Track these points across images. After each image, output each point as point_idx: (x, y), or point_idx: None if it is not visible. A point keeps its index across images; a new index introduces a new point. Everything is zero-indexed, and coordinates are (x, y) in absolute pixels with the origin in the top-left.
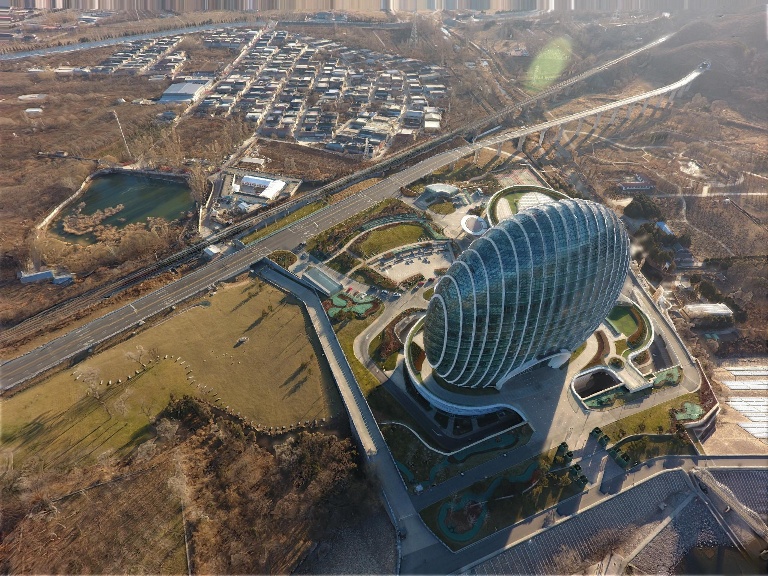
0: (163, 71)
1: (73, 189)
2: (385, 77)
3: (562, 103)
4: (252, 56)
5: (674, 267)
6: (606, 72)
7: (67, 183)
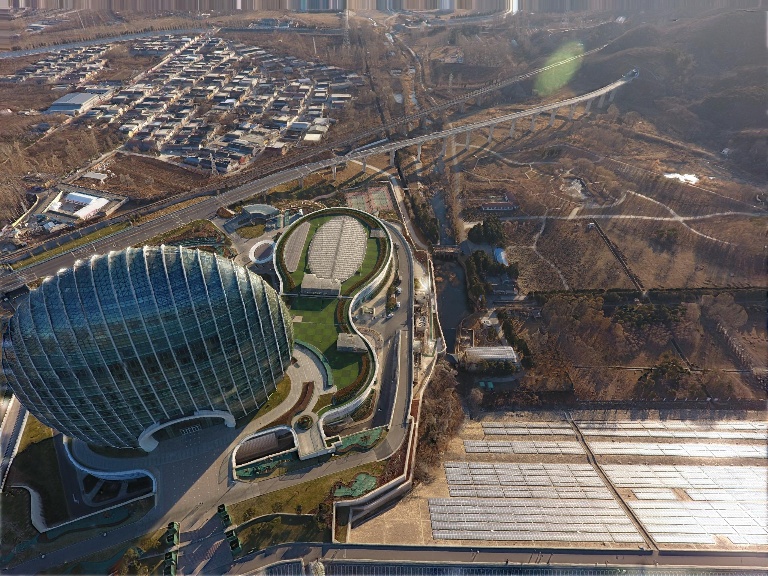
0: (71, 80)
1: None
2: (292, 86)
3: (470, 114)
4: (170, 64)
5: (484, 301)
6: (527, 81)
7: None
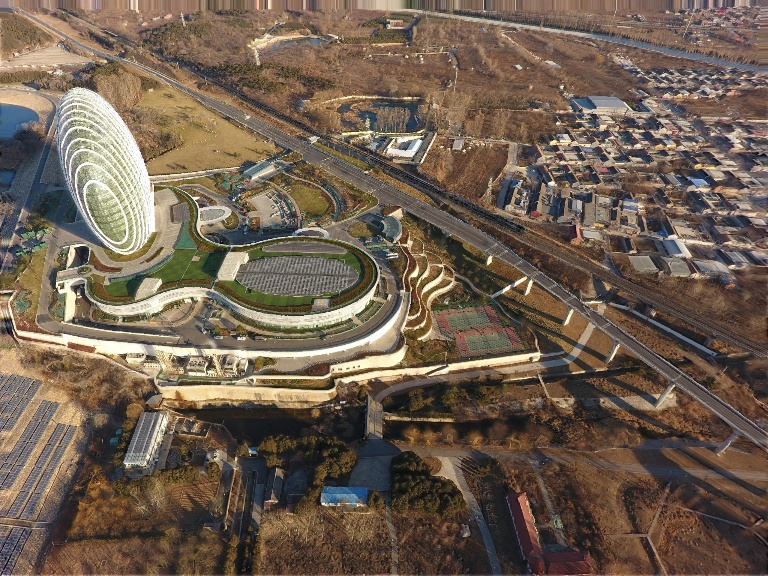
0: None
1: (391, 93)
2: None
3: None
4: None
5: None
6: None
7: (393, 88)
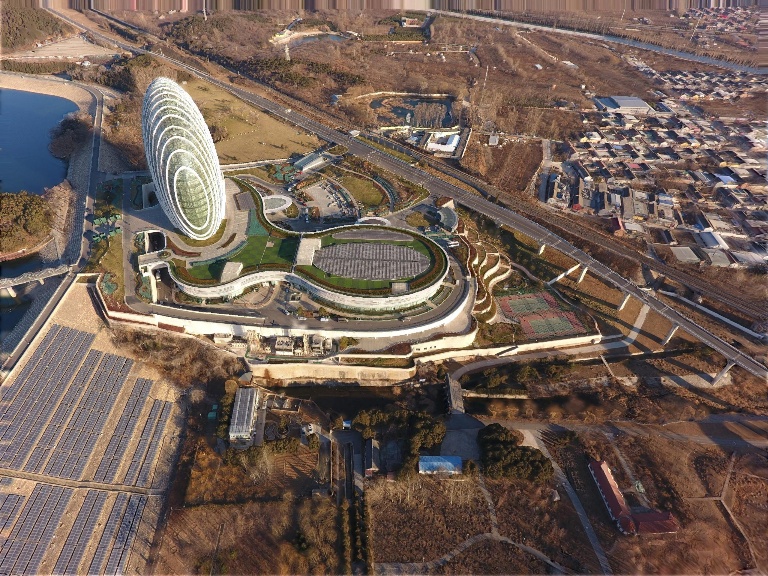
0: None
1: (421, 89)
2: None
3: None
4: None
5: None
6: None
7: (423, 85)
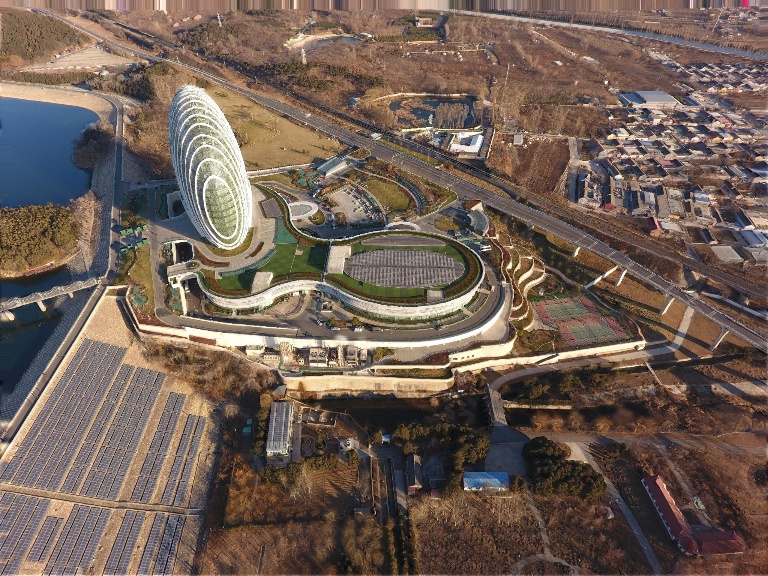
0: None
1: (440, 89)
2: None
3: None
4: None
5: None
6: None
7: (442, 85)
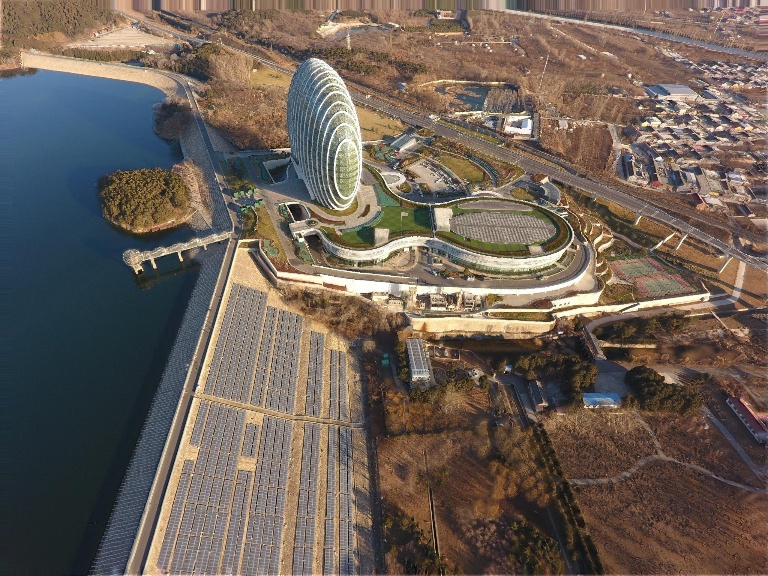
0: None
1: (481, 77)
2: None
3: None
4: None
5: None
6: None
7: (483, 73)
